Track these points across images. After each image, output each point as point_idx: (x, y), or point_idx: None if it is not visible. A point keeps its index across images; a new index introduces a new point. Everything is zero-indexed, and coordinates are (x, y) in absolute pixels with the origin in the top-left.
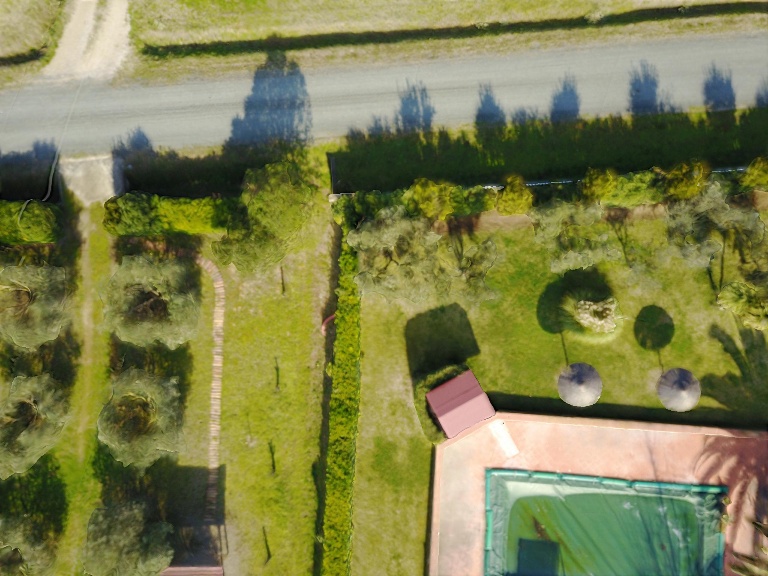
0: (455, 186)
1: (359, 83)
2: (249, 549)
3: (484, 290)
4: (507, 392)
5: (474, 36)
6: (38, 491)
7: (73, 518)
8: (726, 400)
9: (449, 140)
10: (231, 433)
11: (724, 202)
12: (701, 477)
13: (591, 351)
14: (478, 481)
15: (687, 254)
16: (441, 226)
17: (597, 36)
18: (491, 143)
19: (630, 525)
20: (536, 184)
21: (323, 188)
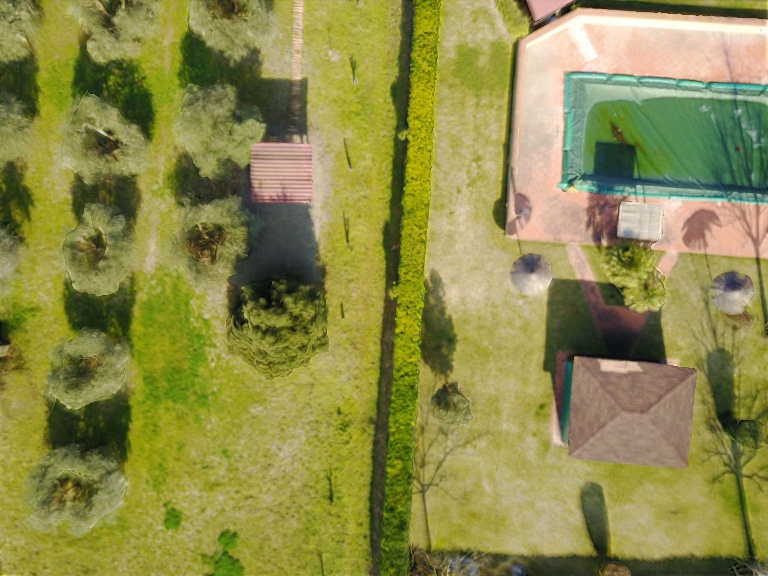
0: None
1: None
2: (330, 161)
3: None
4: None
5: None
6: (125, 99)
7: (159, 127)
8: None
9: None
10: (312, 48)
11: None
12: None
13: None
14: (556, 85)
15: None
16: None
17: None
18: None
19: (704, 128)
20: None
21: None
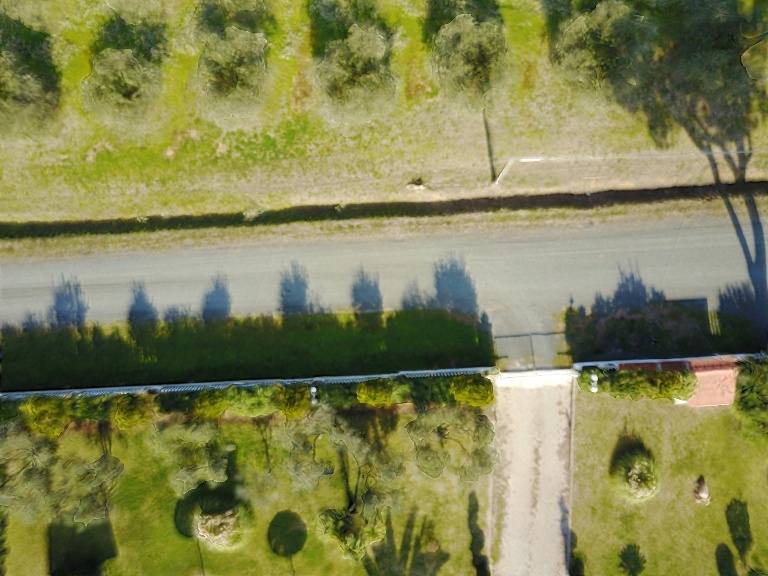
0: (108, 381)
1: (15, 277)
2: None
3: (91, 510)
4: None
5: (131, 231)
6: None
7: None
8: None
9: (104, 335)
10: None
11: (332, 425)
12: None
13: (225, 555)
14: None
15: (297, 474)
16: (92, 422)
17: (251, 235)
18: (145, 339)
19: None
20: (171, 390)
21: None
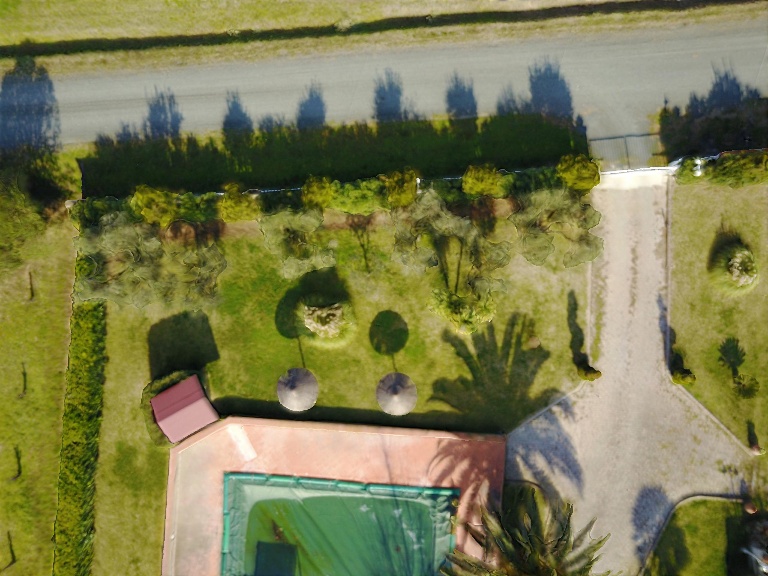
0: (203, 192)
1: (108, 89)
2: None
3: (200, 296)
4: (245, 396)
5: (223, 43)
6: None
7: None
8: (458, 403)
9: (197, 146)
10: None
11: (439, 209)
12: (434, 479)
13: (327, 356)
14: (216, 485)
15: (405, 260)
16: (188, 232)
17: (344, 44)
18: (239, 149)
19: (366, 527)
20: (271, 190)
21: (78, 193)
